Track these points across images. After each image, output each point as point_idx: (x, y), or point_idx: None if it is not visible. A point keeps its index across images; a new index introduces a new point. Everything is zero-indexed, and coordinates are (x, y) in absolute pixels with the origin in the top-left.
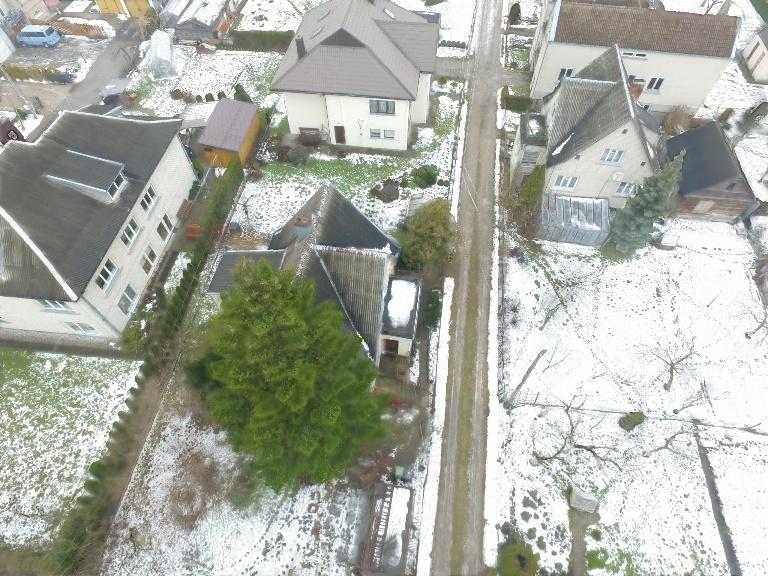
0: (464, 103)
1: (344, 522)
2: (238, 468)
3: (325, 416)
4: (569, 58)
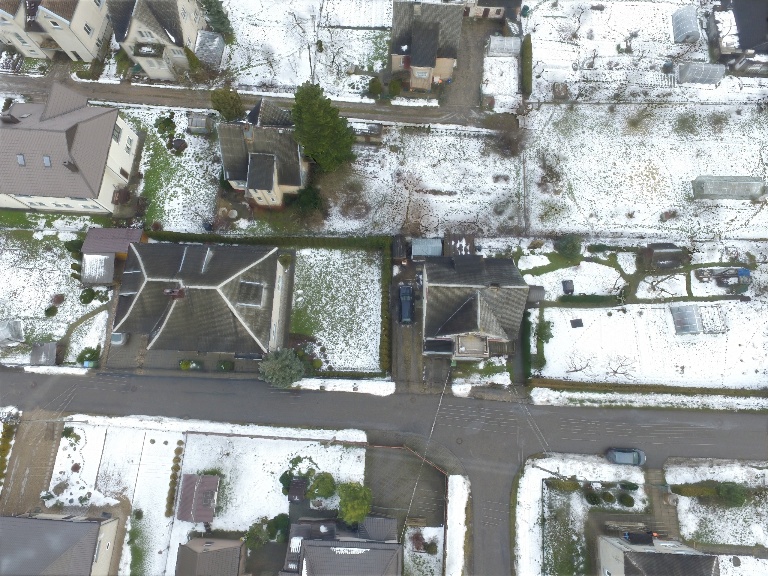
0: (89, 102)
1: (364, 151)
2: (346, 191)
3: (336, 113)
4: (80, 20)
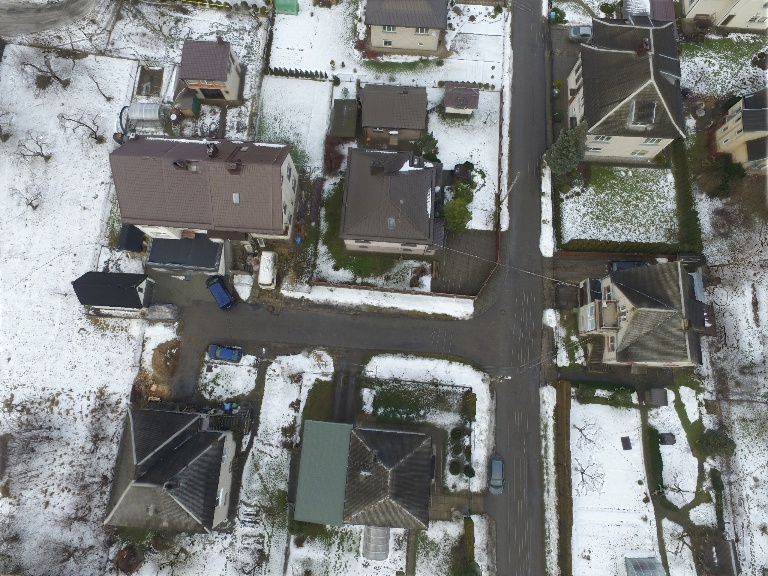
0: None
1: None
2: (742, 213)
3: None
4: None
